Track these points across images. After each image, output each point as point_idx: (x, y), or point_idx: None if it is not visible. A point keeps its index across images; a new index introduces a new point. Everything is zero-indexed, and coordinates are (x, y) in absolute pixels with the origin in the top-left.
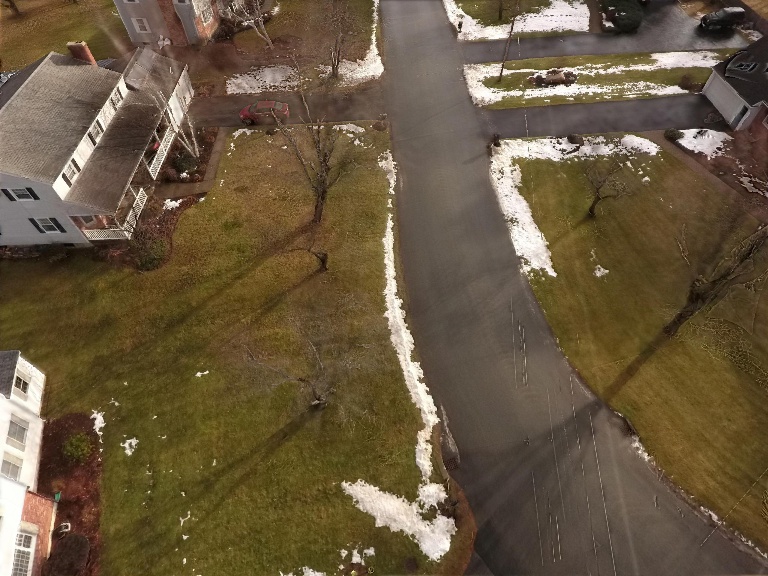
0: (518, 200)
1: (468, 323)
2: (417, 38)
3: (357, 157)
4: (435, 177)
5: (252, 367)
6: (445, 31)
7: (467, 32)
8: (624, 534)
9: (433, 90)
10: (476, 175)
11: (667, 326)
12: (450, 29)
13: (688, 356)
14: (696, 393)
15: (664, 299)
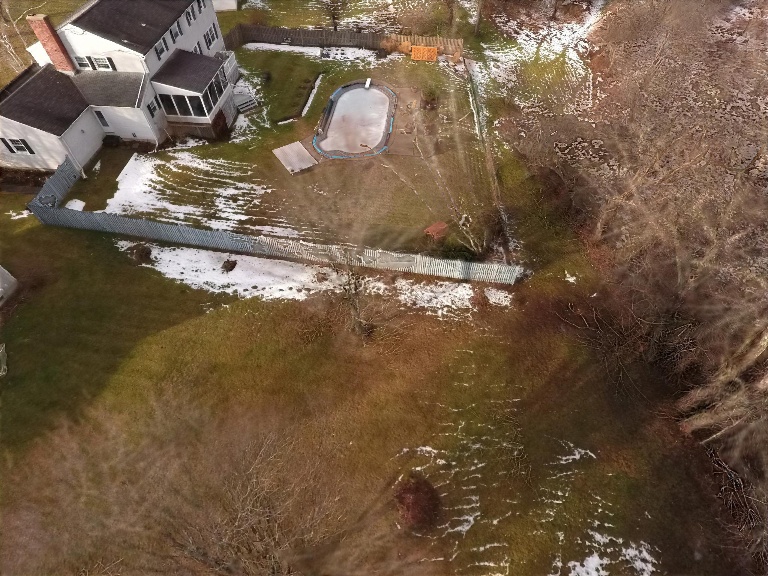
0: None
1: None
2: None
3: None
4: None
5: (79, 2)
6: None
7: None
8: None
9: None
10: None
11: None
12: None
13: None
14: None
15: None
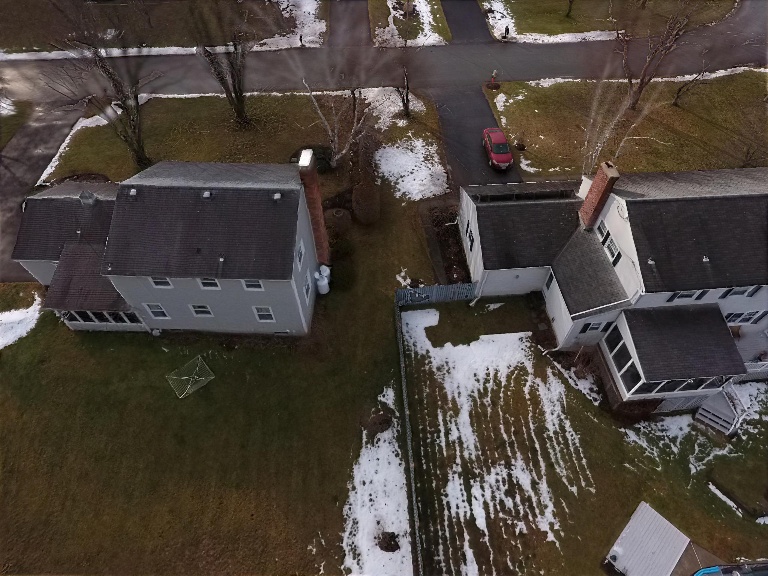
0: (563, 36)
1: (679, 56)
2: (316, 68)
3: (543, 96)
4: (554, 62)
5: (765, 130)
6: (298, 54)
7: (306, 42)
8: (752, 31)
9: (426, 61)
10: (543, 48)
11: (643, 7)
12: (294, 51)
13: (655, 7)
14: (674, 8)
15: (622, 7)
